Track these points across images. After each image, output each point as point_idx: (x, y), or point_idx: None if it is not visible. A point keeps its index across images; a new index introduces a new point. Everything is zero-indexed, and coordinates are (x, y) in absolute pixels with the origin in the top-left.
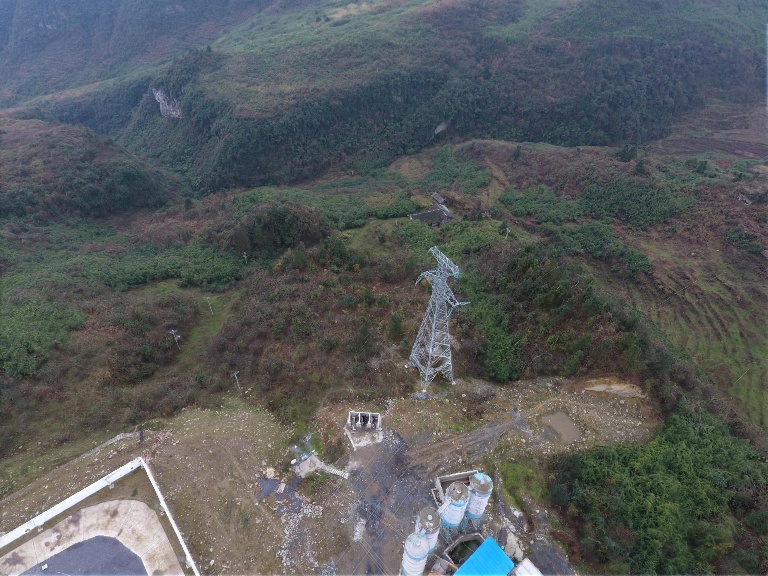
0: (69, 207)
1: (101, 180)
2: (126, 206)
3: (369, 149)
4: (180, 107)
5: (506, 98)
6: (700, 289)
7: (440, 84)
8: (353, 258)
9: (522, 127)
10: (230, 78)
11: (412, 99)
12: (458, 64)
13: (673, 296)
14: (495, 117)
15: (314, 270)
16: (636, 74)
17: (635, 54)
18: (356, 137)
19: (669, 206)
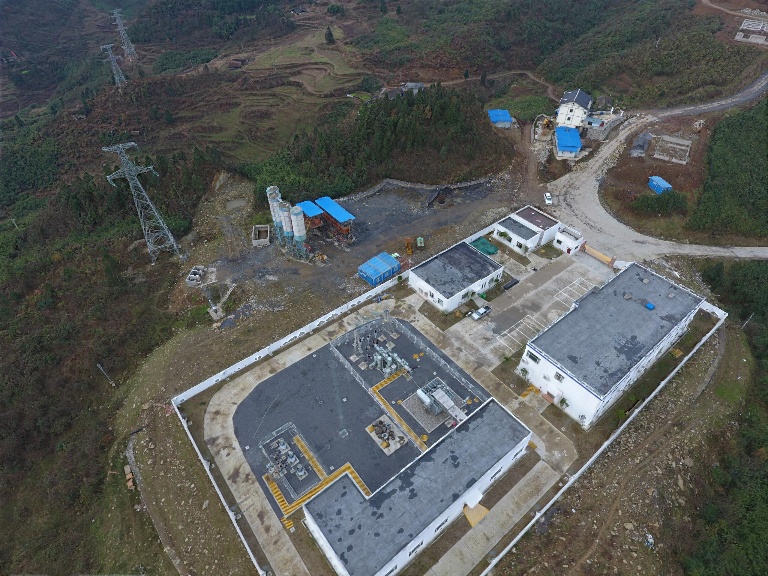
0: None
1: None
2: None
3: None
4: None
5: None
6: None
7: None
8: None
9: None
10: None
11: None
12: None
13: None
14: None
15: None
16: None
17: None
18: None
19: (46, 154)
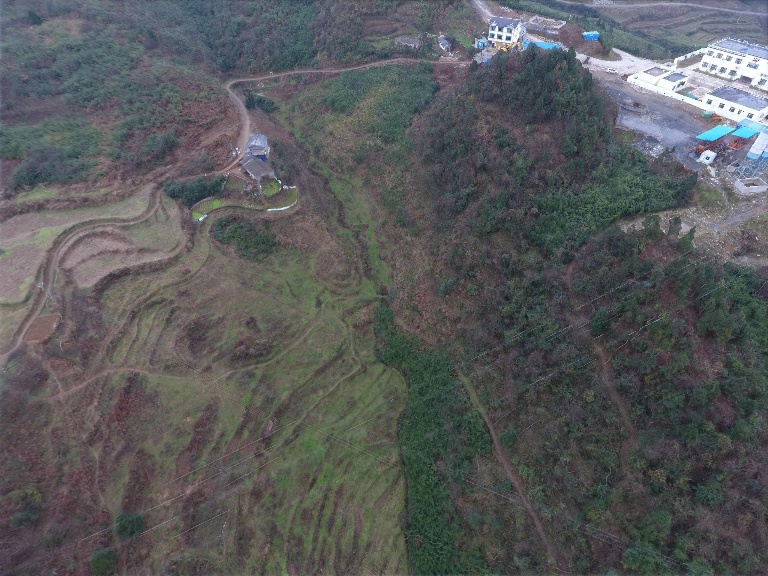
0: None
1: None
2: None
3: None
4: None
5: None
6: None
7: None
8: None
9: None
10: None
11: None
12: None
13: None
14: None
15: None
16: None
17: None
18: None
19: None
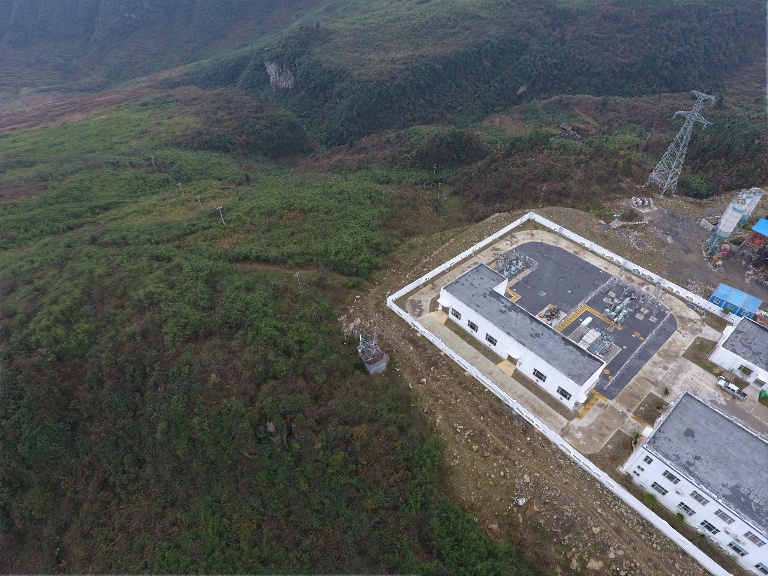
0: (254, 148)
1: (271, 128)
2: (289, 150)
3: (465, 107)
4: (296, 76)
5: (580, 61)
6: None
7: (522, 50)
8: (553, 148)
9: (595, 86)
10: (341, 49)
11: (499, 64)
12: (537, 32)
13: None
14: (570, 78)
15: (537, 151)
16: (695, 36)
17: (693, 19)
18: (454, 97)
19: (749, 130)
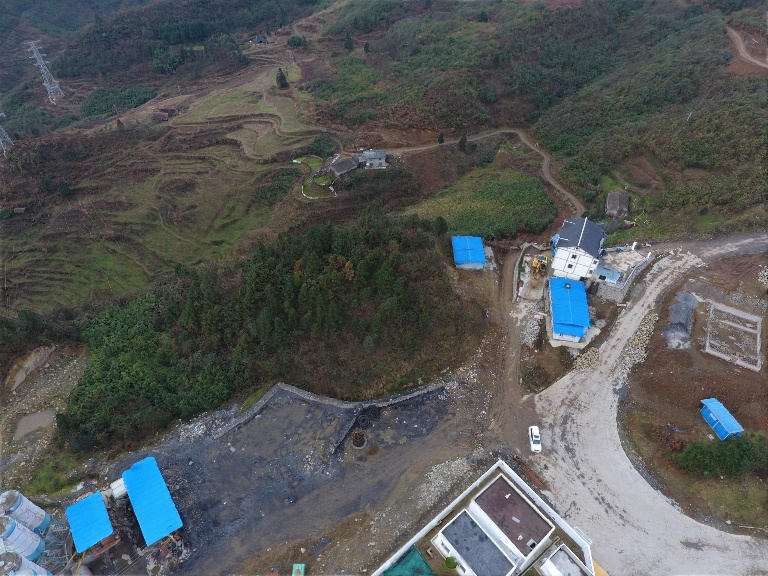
0: None
1: None
2: None
3: None
4: None
5: None
6: (16, 269)
7: None
8: None
9: None
10: None
11: None
12: None
13: (7, 291)
14: None
15: None
16: None
17: None
18: None
19: None
